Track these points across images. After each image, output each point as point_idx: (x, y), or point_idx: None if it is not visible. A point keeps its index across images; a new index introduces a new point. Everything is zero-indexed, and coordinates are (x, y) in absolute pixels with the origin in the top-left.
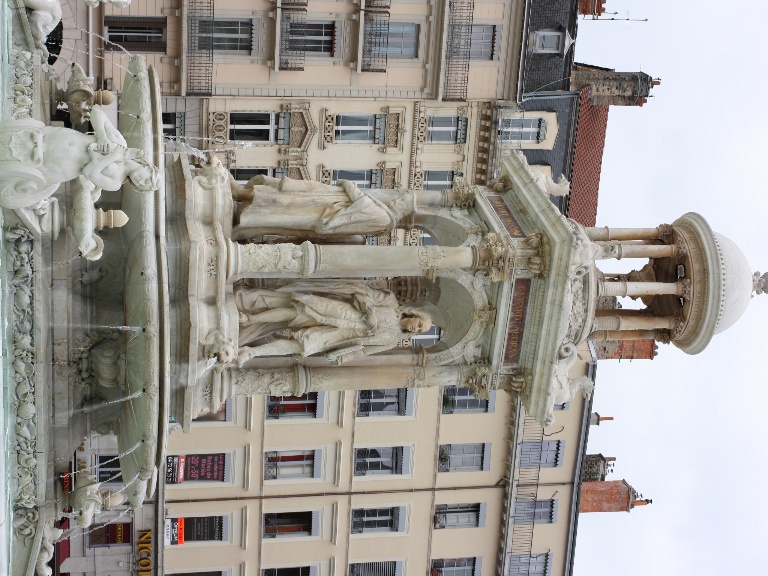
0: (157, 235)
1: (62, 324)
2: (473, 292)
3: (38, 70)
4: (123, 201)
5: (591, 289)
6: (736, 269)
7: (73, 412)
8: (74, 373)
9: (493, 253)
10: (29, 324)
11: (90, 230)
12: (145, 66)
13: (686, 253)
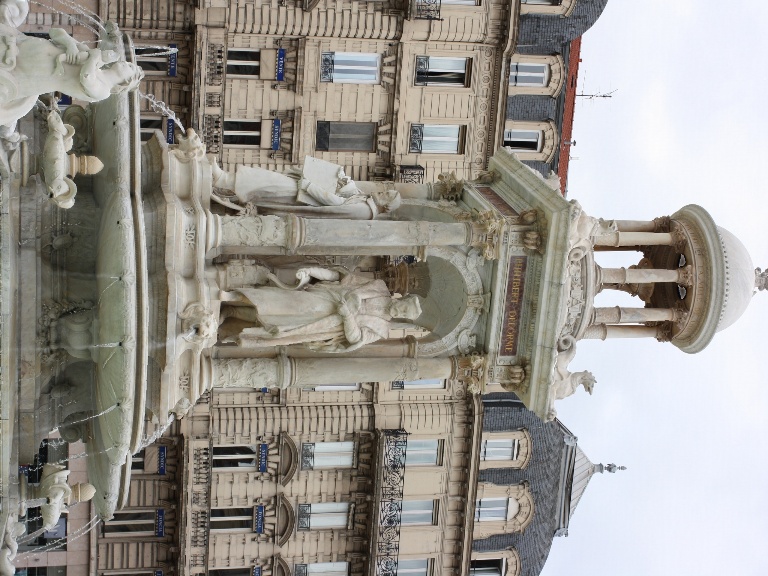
0: None
1: None
2: None
3: (7, 333)
4: None
5: None
6: None
7: None
8: None
9: None
10: None
11: None
12: (133, 369)
13: None
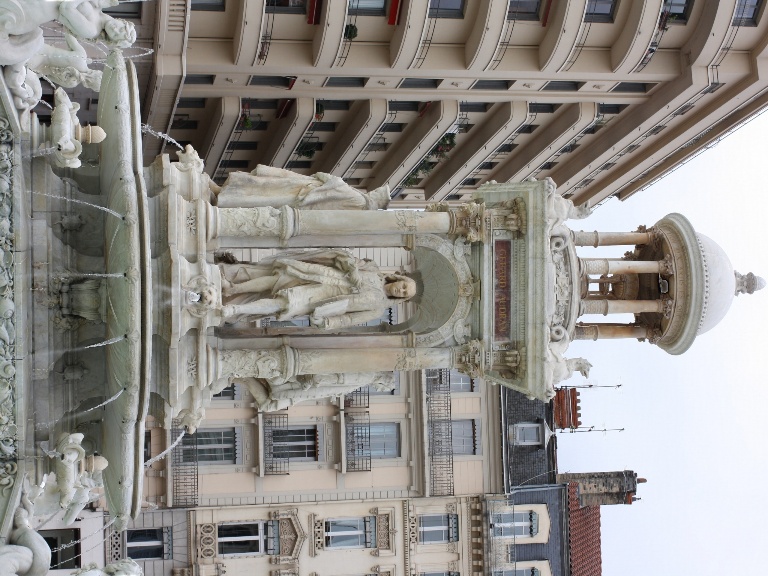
0: (135, 172)
1: (42, 244)
2: (455, 264)
3: None
4: (101, 161)
5: (572, 261)
6: (714, 250)
7: (54, 374)
8: (54, 305)
9: (469, 210)
10: (8, 207)
11: (68, 133)
12: None
13: (662, 235)
